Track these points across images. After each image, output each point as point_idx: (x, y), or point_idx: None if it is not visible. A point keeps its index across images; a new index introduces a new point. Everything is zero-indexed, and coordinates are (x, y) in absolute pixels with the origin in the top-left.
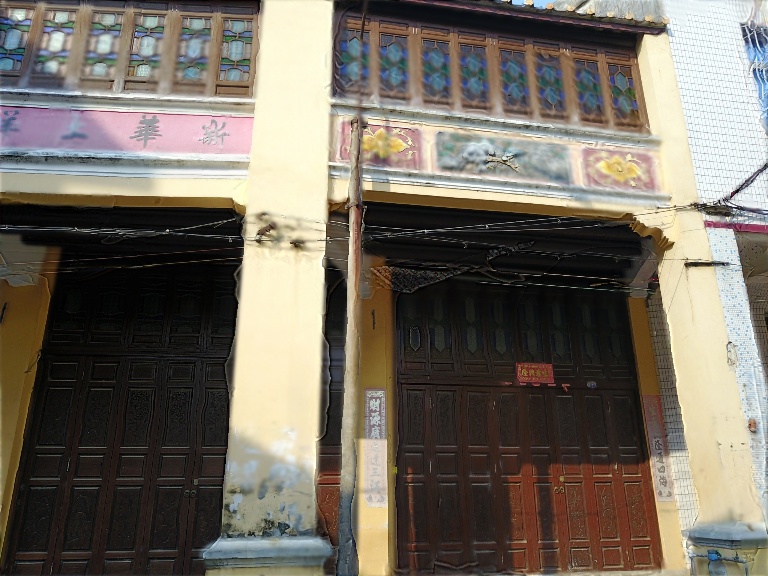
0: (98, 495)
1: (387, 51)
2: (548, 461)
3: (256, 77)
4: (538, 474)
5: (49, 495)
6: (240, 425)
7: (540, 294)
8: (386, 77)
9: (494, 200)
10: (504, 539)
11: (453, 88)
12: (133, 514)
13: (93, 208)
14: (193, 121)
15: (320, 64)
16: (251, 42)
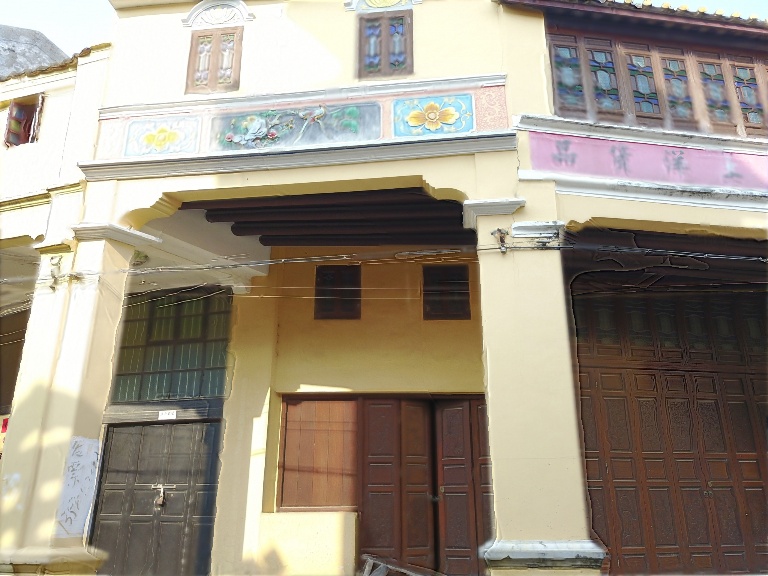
0: (637, 495)
1: None
2: None
3: None
4: None
5: (598, 495)
6: None
7: None
8: None
9: None
10: None
11: None
12: (668, 513)
13: None
14: None
15: None
16: None
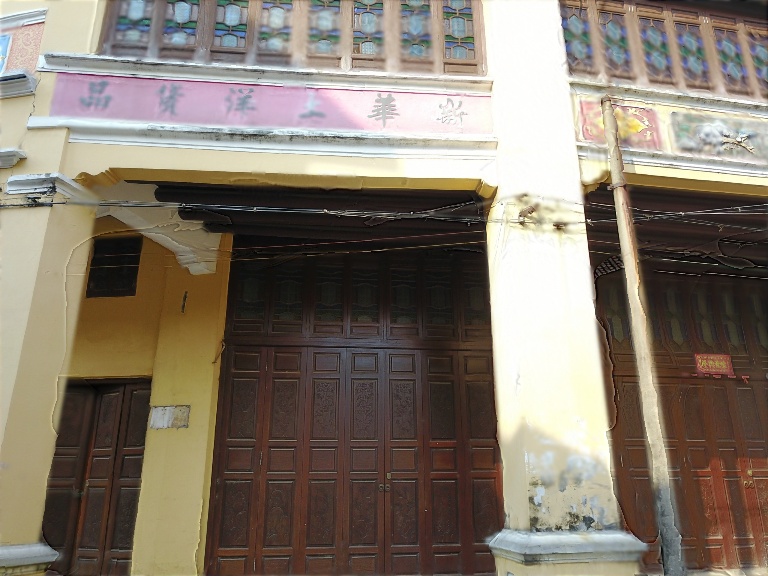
0: (293, 489)
1: (606, 29)
2: (735, 455)
3: (494, 54)
4: (726, 468)
5: (244, 489)
6: (532, 414)
7: (714, 283)
8: (609, 56)
9: (734, 182)
10: (703, 535)
11: (675, 67)
12: (329, 509)
13: (341, 189)
14: (429, 100)
15: (554, 41)
16: (472, 19)
